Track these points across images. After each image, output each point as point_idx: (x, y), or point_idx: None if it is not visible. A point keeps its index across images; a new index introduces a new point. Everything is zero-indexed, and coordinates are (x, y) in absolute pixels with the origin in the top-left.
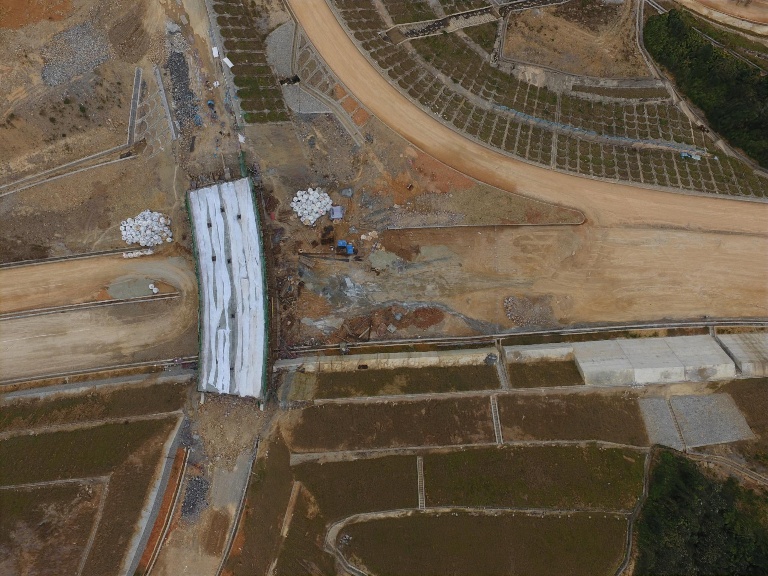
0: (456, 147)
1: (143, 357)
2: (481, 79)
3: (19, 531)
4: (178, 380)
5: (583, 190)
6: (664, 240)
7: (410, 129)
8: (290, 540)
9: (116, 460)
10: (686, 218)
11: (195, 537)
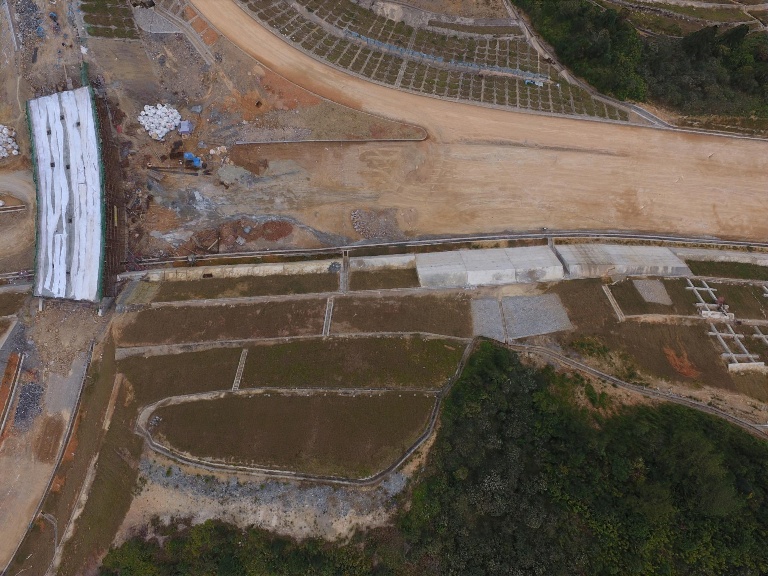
0: (303, 67)
1: None
2: (338, 11)
3: None
4: (19, 290)
5: (425, 108)
6: (503, 156)
7: (258, 49)
8: (111, 432)
9: None
10: (523, 135)
11: (28, 444)
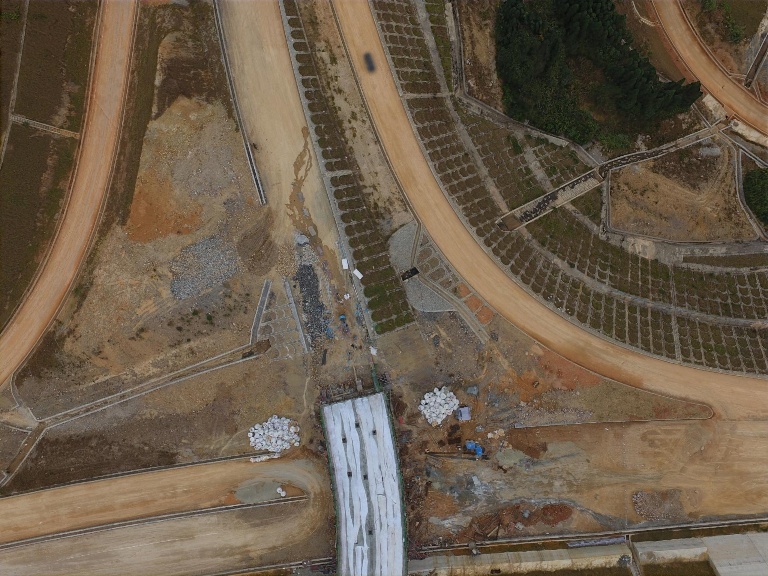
0: (581, 343)
1: (271, 559)
2: (594, 257)
3: None
4: None
5: (710, 383)
6: None
7: (535, 326)
8: None
9: None
10: None
11: None
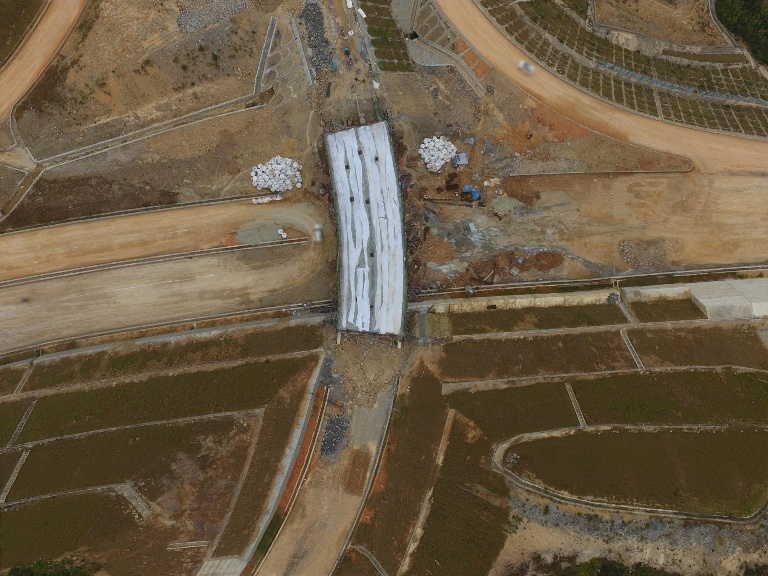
0: (571, 99)
1: (271, 302)
2: (582, 41)
3: (180, 462)
4: (311, 322)
5: (690, 140)
6: (765, 187)
7: (528, 81)
8: (447, 467)
9: (267, 394)
10: None
11: (335, 476)
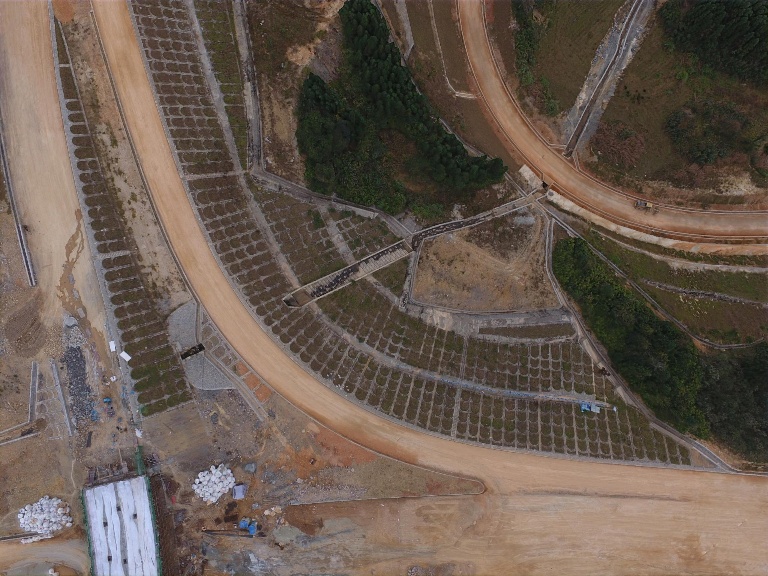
0: (358, 420)
1: None
2: (388, 331)
3: None
4: None
5: (483, 459)
6: (562, 505)
7: (312, 403)
8: None
9: None
10: (583, 484)
11: None
